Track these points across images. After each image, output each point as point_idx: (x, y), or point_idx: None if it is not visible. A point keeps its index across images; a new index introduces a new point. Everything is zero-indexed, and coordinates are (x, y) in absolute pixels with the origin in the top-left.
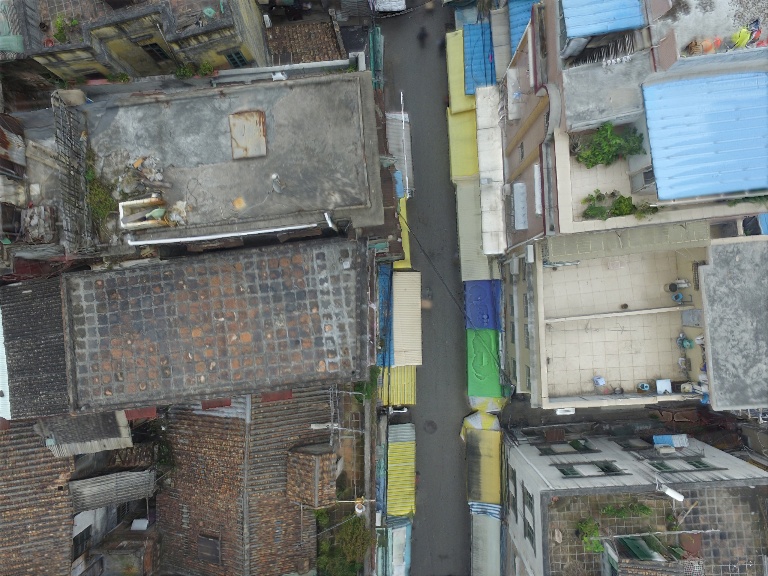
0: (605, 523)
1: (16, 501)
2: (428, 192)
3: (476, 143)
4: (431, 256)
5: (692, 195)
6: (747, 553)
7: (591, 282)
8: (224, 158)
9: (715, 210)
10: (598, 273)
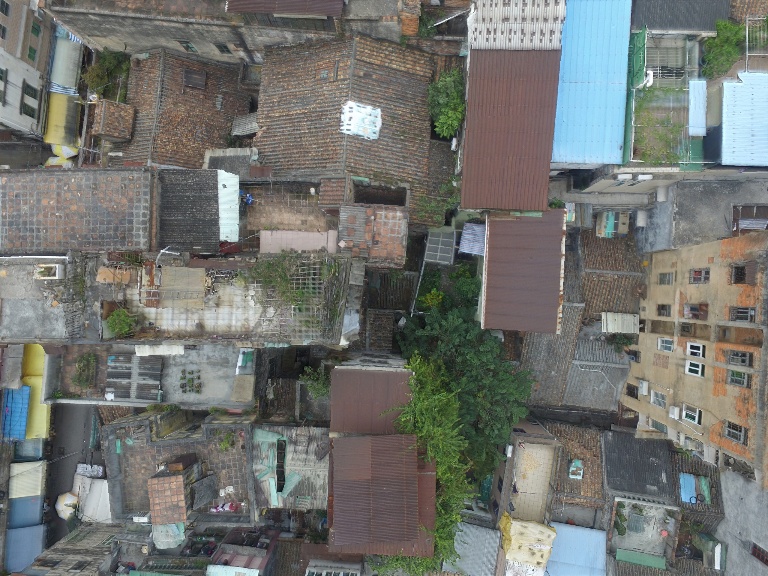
0: None
1: (281, 121)
2: None
3: (32, 351)
4: None
5: None
6: None
7: None
8: (8, 301)
9: None
10: None
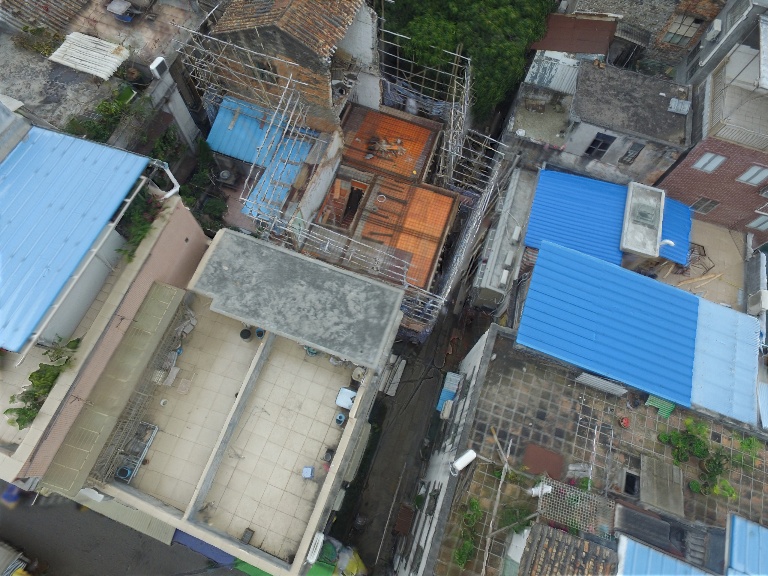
0: (480, 568)
1: None
2: (63, 521)
3: None
4: (139, 558)
5: (45, 310)
6: (569, 397)
7: (190, 422)
8: None
9: (125, 278)
10: (185, 408)
